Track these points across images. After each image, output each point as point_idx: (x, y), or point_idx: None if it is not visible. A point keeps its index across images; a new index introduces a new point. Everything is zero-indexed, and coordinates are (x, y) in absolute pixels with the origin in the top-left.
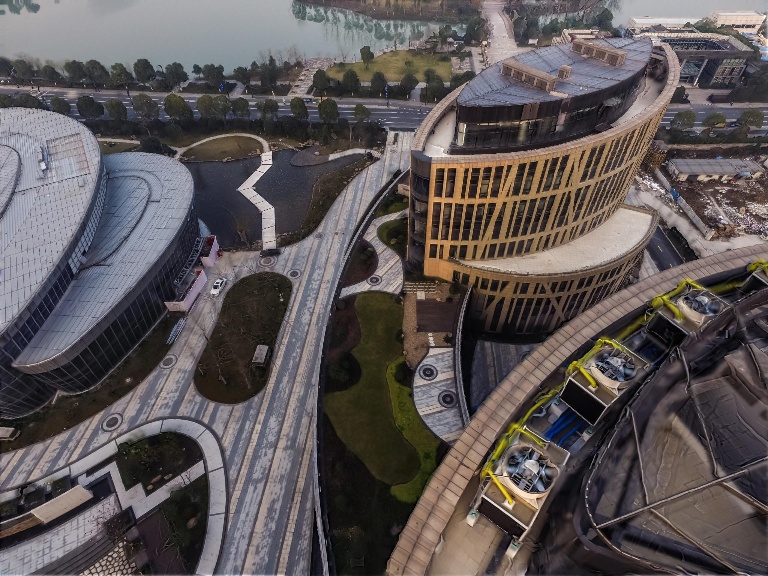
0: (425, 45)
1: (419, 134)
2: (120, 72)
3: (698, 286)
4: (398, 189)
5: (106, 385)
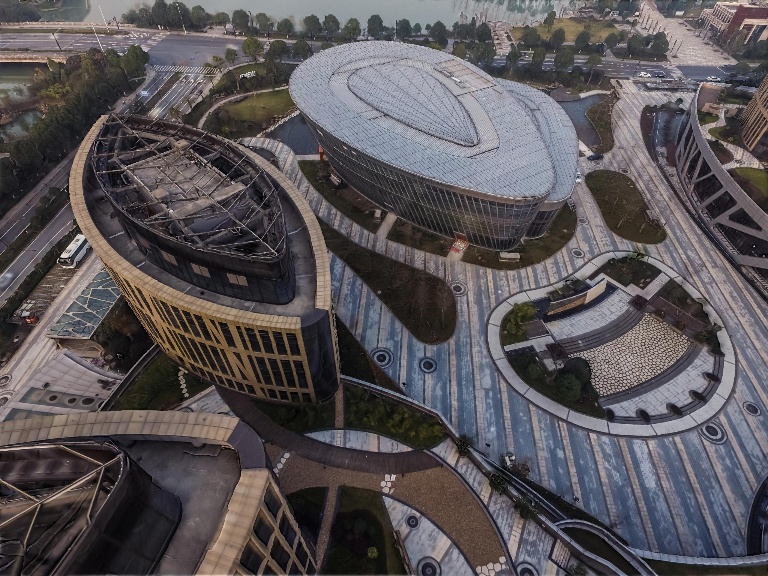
0: (581, 14)
1: None
2: (356, 26)
3: None
4: (703, 107)
5: (552, 233)
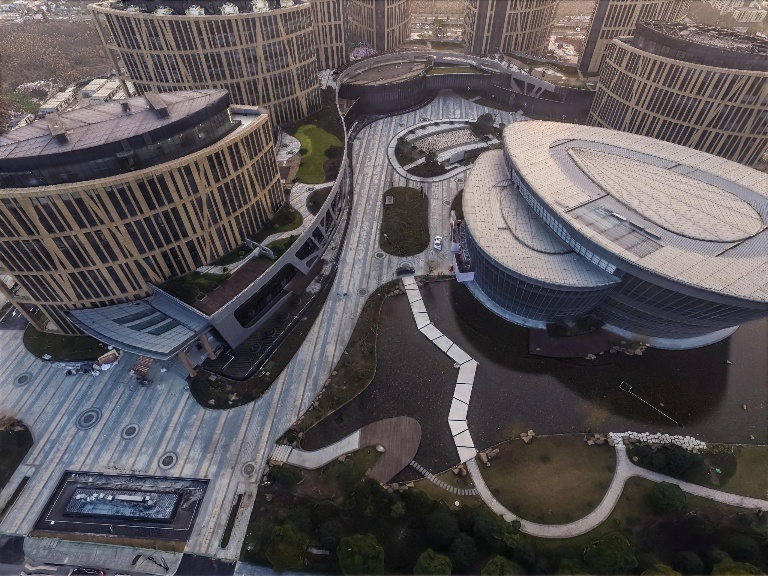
0: None
1: (257, 122)
2: None
3: (222, 7)
4: None
5: None
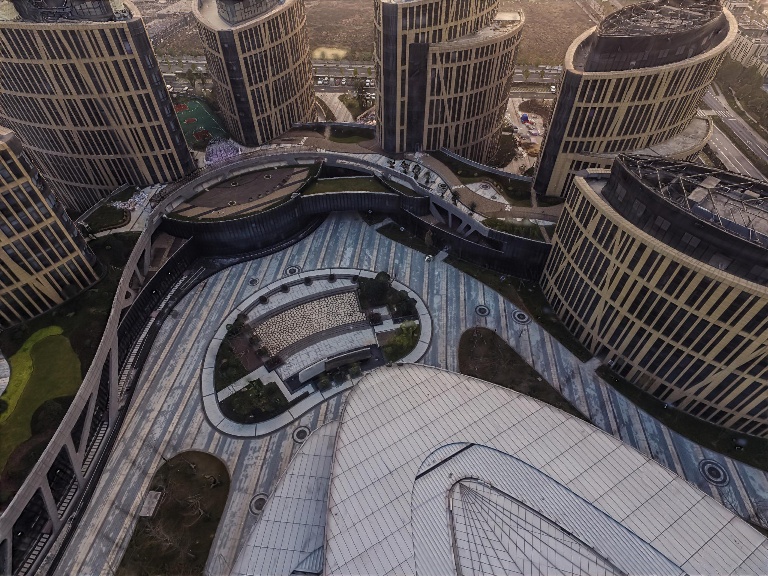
0: None
1: None
2: None
3: None
4: None
5: None
